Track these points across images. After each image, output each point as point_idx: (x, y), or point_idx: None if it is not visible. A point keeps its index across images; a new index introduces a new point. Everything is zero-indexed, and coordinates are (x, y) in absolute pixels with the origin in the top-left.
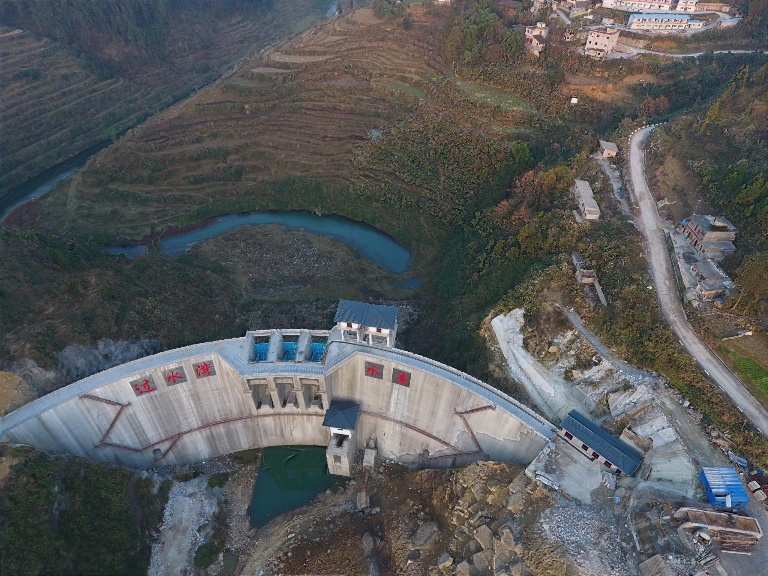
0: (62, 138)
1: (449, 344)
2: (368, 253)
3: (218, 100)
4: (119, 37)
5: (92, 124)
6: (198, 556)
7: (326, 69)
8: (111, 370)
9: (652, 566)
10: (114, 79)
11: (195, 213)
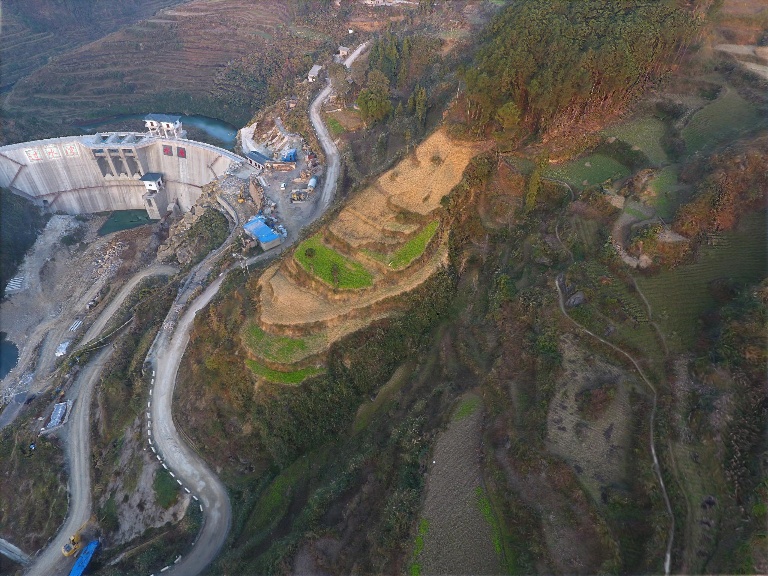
0: (1, 71)
1: None
2: (214, 133)
3: (119, 40)
4: (51, 2)
5: (26, 63)
6: (63, 238)
7: (205, 21)
8: (15, 145)
9: None
10: (46, 32)
11: (96, 112)
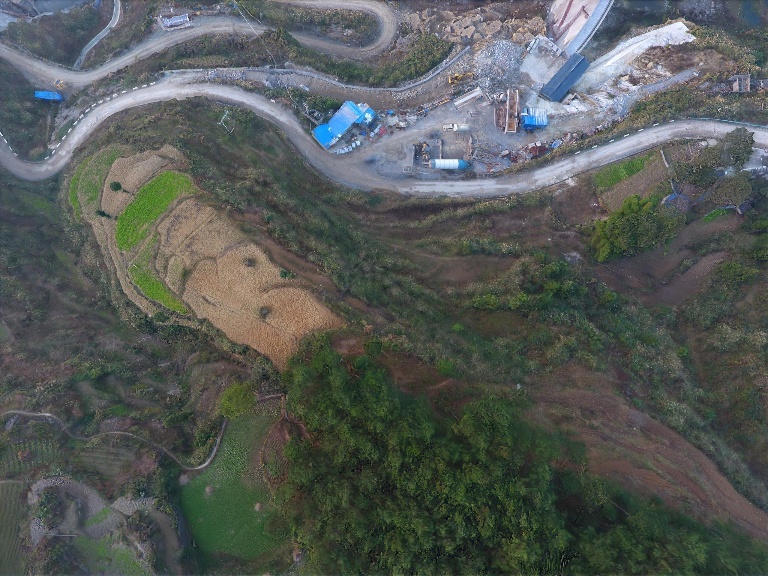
0: None
1: None
2: None
3: None
4: None
5: None
6: None
7: None
8: None
9: None
10: None
11: None
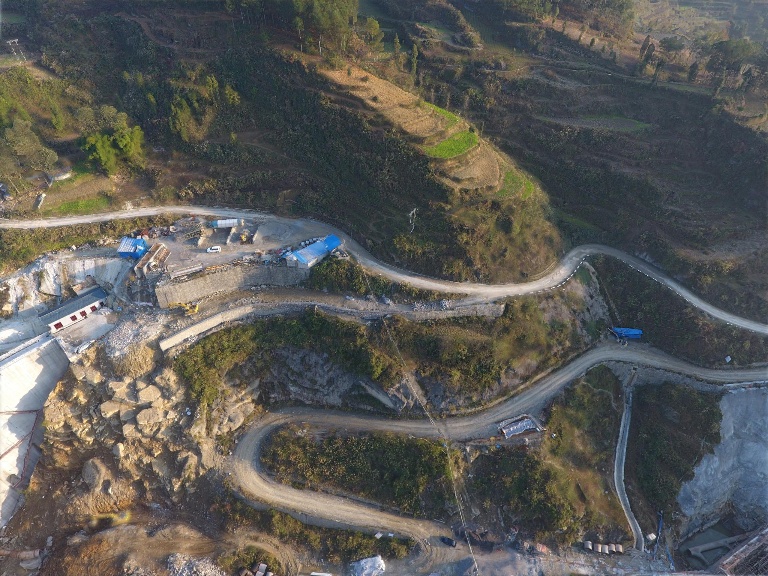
0: None
1: None
2: None
3: None
4: None
5: None
6: None
7: None
8: None
9: (161, 298)
10: None
11: None
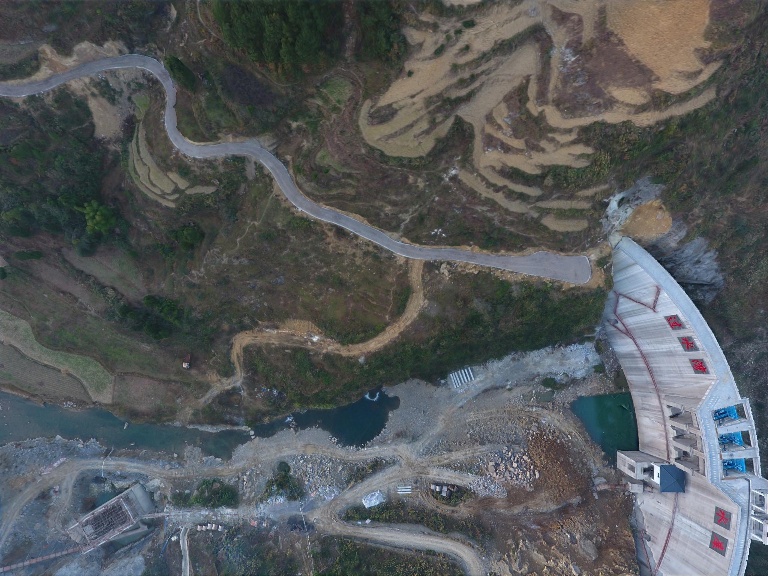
0: None
1: (764, 564)
2: None
3: None
4: None
5: None
6: (549, 381)
7: None
8: (686, 296)
9: None
10: None
11: None
